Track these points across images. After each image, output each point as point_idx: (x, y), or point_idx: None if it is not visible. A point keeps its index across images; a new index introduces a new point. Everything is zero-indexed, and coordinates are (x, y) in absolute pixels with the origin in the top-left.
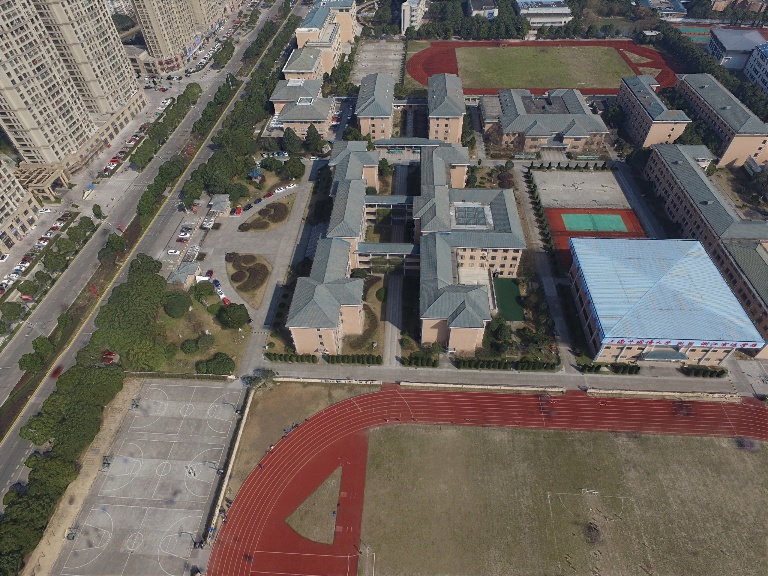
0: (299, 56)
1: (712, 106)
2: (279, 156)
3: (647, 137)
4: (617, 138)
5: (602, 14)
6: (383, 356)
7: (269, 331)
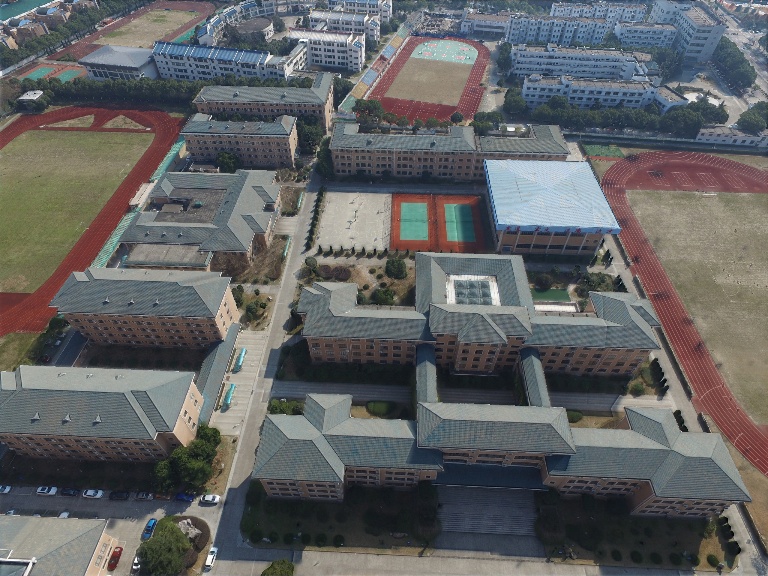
0: None
1: (272, 101)
2: None
3: (291, 152)
4: None
5: None
6: None
7: (690, 570)
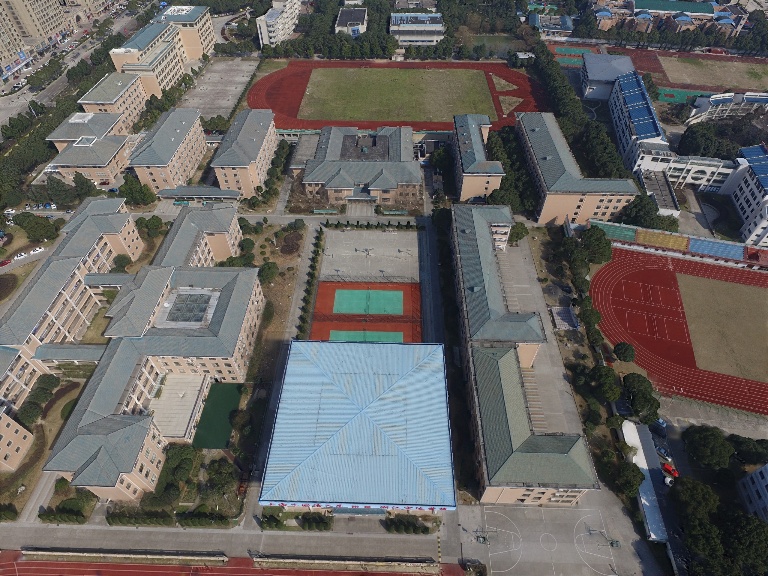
0: (100, 84)
1: (535, 154)
2: (45, 208)
3: (462, 190)
4: None
5: (485, 31)
6: (24, 506)
7: None
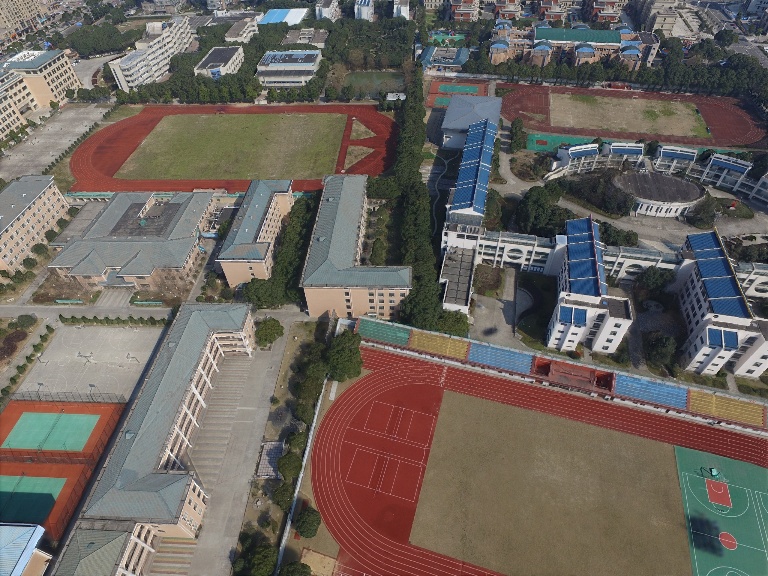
0: None
1: (315, 233)
2: None
3: (226, 276)
4: (210, 270)
5: (371, 67)
6: None
7: None
